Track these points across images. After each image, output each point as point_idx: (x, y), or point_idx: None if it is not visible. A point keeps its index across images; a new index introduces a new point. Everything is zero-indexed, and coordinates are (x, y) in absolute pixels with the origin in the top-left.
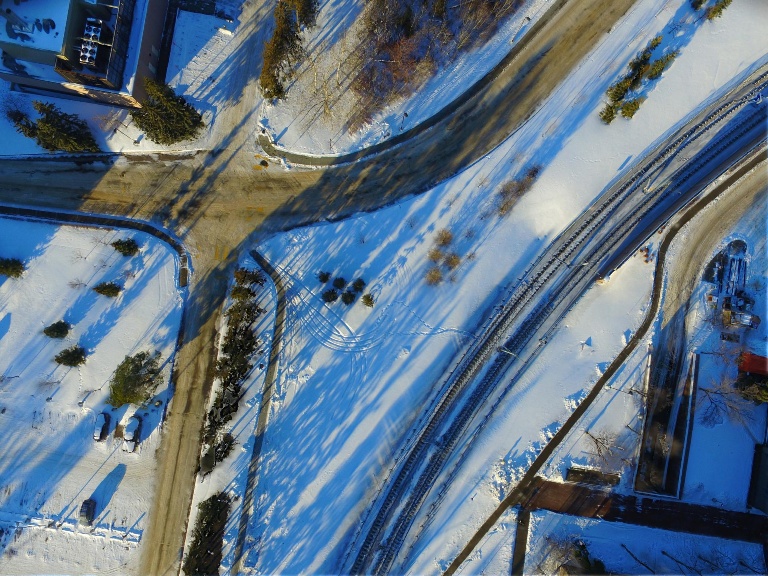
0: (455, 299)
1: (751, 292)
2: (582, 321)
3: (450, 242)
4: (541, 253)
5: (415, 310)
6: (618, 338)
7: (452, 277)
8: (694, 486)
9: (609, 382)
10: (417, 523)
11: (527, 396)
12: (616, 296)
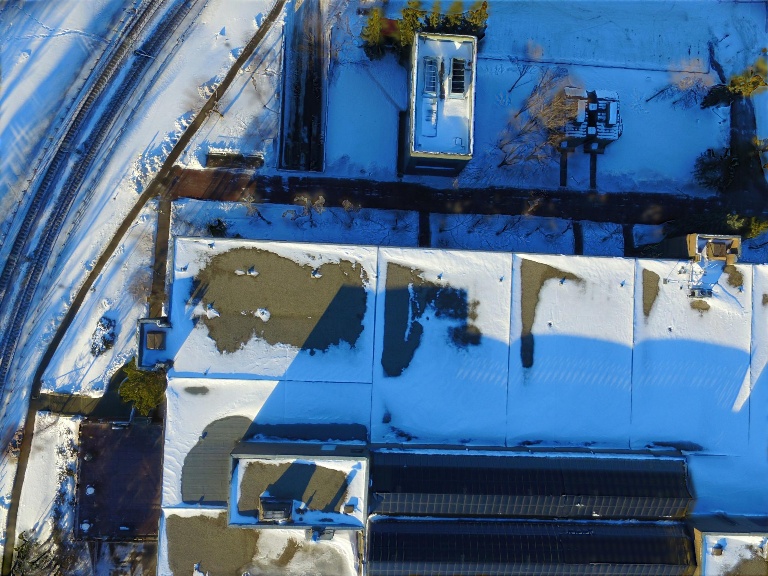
0: None
1: None
2: (217, 14)
3: None
4: None
5: (31, 12)
6: (250, 23)
7: None
8: (338, 157)
9: (243, 66)
10: (64, 232)
11: (165, 93)
12: None
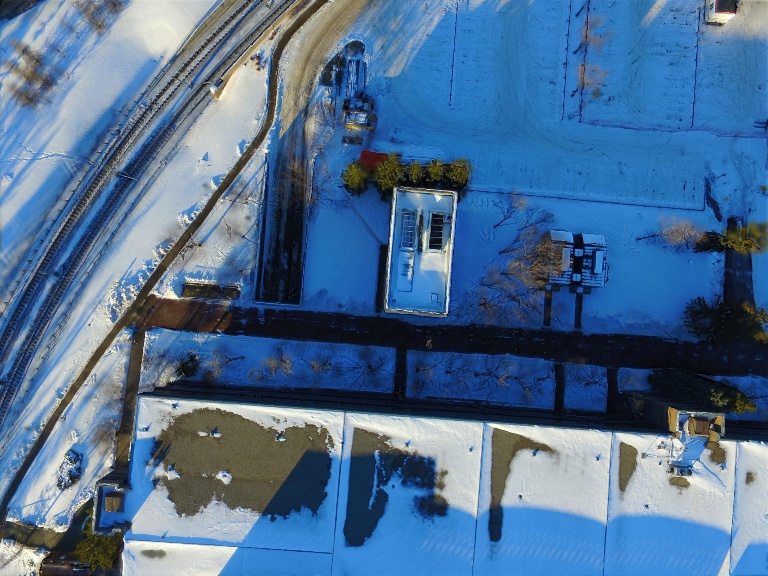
0: (57, 122)
1: (373, 93)
2: (201, 138)
3: (45, 63)
4: (157, 74)
5: (15, 136)
6: (233, 150)
7: (50, 98)
8: (315, 292)
9: (224, 194)
10: (38, 356)
11: (145, 218)
12: (232, 108)
